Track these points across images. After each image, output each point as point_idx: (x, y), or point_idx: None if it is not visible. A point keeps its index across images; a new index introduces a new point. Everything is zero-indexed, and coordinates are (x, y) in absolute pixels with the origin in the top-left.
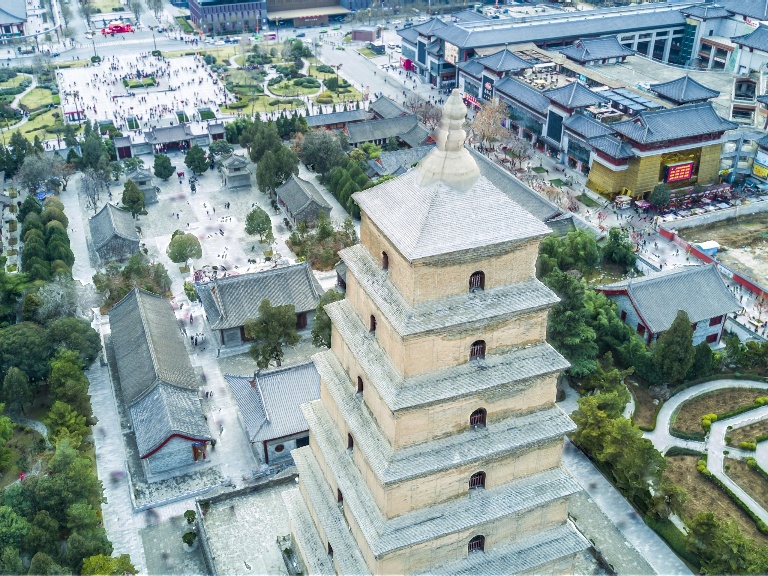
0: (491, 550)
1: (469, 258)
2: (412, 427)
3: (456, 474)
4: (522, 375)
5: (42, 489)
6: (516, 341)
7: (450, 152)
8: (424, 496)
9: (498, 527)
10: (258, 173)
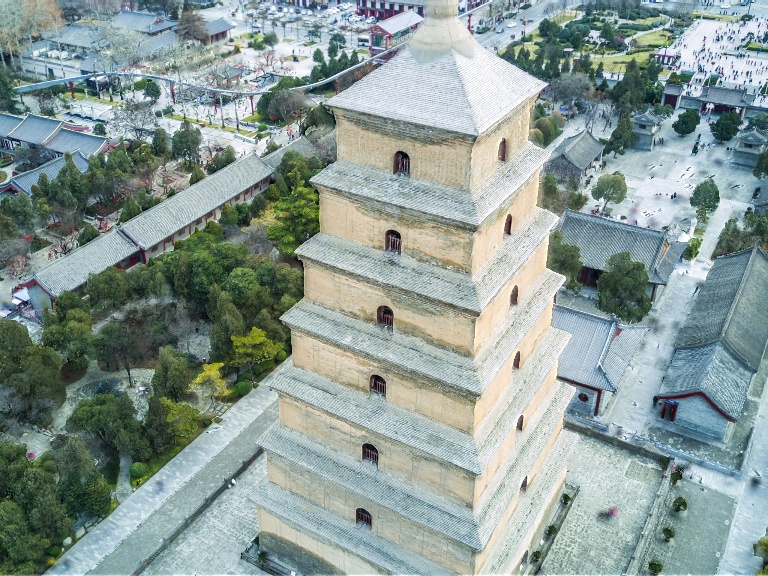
0: (386, 473)
1: (391, 131)
2: (320, 285)
3: (356, 362)
4: (424, 291)
5: (280, 273)
6: (435, 253)
7: (428, 18)
8: (326, 364)
9: (393, 451)
10: (761, 154)
